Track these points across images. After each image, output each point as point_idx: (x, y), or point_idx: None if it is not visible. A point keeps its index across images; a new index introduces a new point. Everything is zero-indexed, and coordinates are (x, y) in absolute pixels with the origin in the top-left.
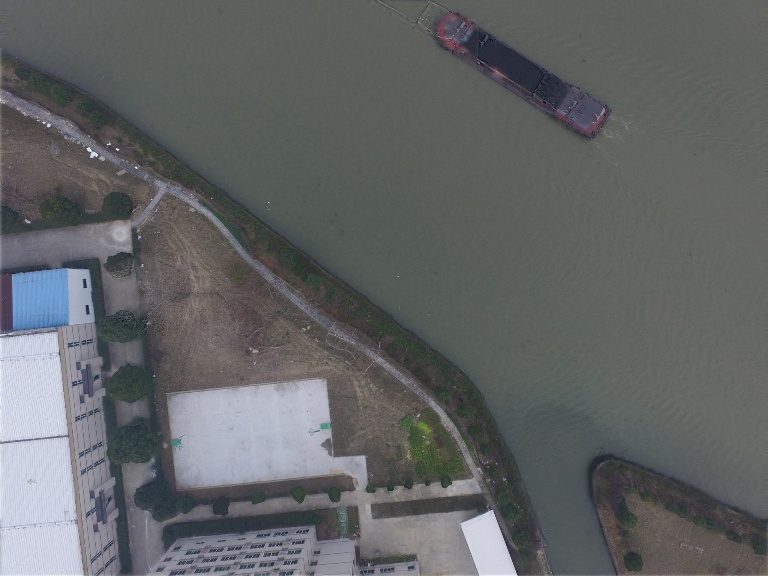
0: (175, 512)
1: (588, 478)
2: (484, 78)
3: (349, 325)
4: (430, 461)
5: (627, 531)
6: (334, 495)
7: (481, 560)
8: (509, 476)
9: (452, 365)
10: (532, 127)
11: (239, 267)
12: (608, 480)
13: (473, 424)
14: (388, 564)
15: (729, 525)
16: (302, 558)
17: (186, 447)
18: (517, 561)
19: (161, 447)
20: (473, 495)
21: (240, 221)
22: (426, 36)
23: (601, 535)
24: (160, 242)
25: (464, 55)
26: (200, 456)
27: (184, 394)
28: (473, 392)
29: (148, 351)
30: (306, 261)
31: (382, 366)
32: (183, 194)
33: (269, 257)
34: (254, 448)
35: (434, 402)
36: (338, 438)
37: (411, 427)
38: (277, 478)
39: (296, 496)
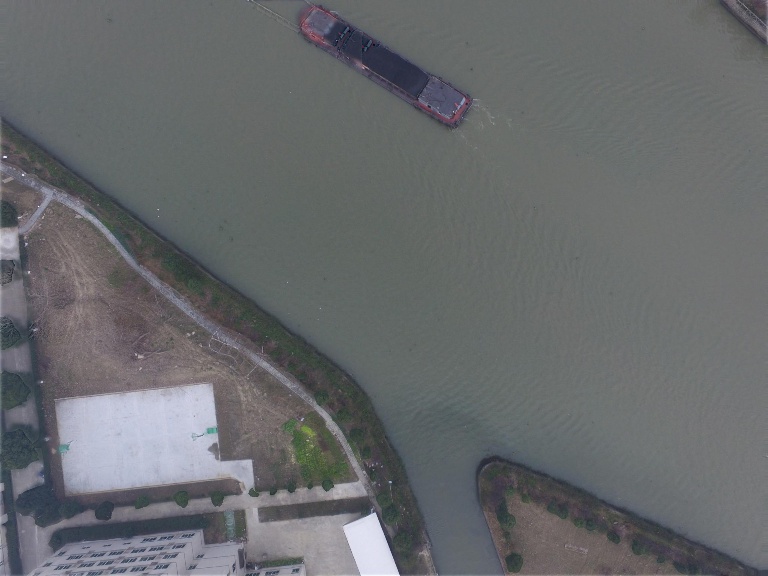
0: (59, 517)
1: (476, 480)
2: (369, 83)
3: (233, 330)
4: (314, 464)
5: (509, 532)
6: (215, 499)
7: (363, 562)
8: (394, 479)
9: (338, 369)
10: (417, 131)
11: (125, 273)
12: (492, 482)
13: (358, 427)
14: (275, 567)
15: (612, 526)
16: (175, 562)
17: (74, 452)
18: (402, 563)
19: (49, 453)
20: (359, 498)
21: (126, 227)
22: (311, 42)
23: (489, 536)
24: (45, 249)
25: (349, 60)
26: (88, 461)
27: (72, 400)
28: (357, 396)
29: (36, 357)
30: (191, 267)
31: (267, 370)
32: (69, 201)
33: (156, 263)
34: (142, 453)
35: (319, 406)
36: (224, 442)
37: (294, 431)
38: (165, 482)
39: (178, 500)
